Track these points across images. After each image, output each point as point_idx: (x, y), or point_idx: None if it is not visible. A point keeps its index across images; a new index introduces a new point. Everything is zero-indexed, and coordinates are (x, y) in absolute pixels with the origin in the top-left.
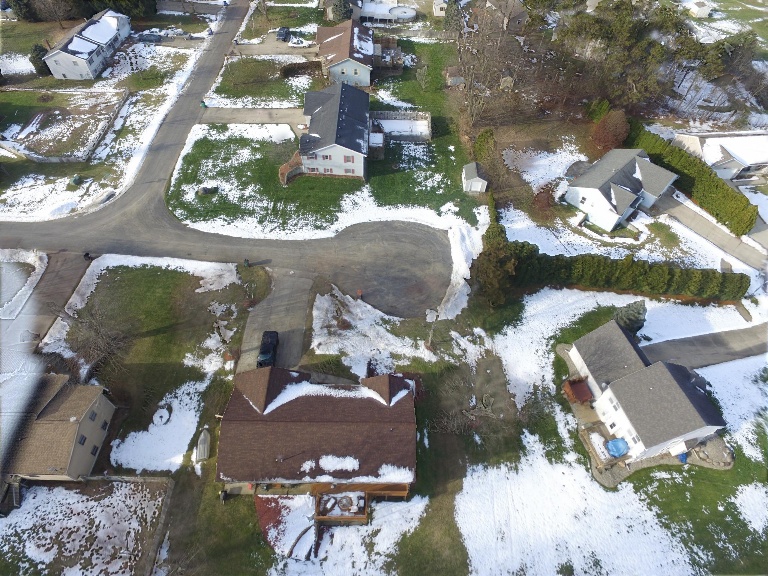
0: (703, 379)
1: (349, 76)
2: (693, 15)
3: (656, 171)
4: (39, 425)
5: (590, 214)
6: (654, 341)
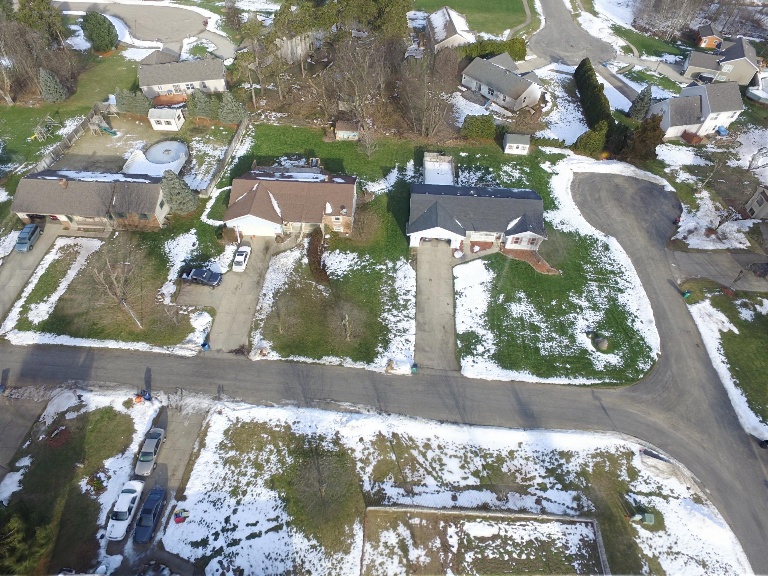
0: None
1: None
2: None
3: (502, 58)
4: None
5: (528, 104)
6: None
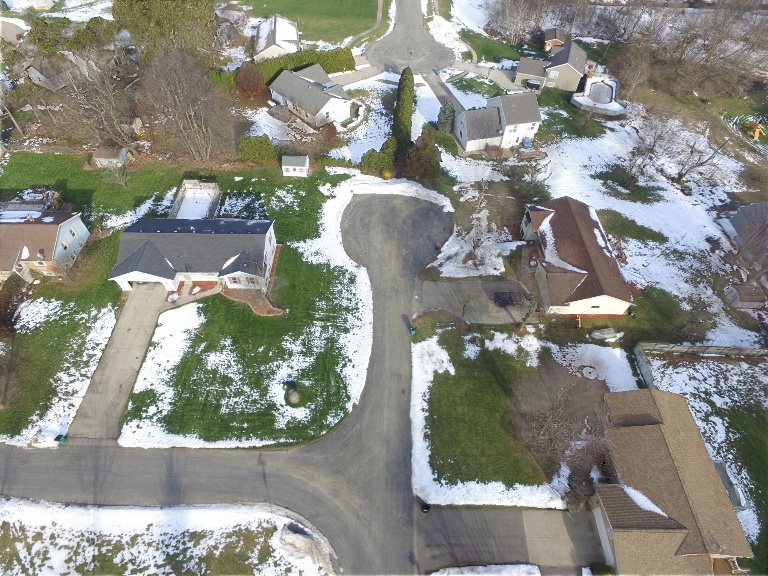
0: (498, 92)
1: (71, 245)
2: (45, 9)
3: (311, 71)
4: (666, 420)
5: (336, 119)
6: None
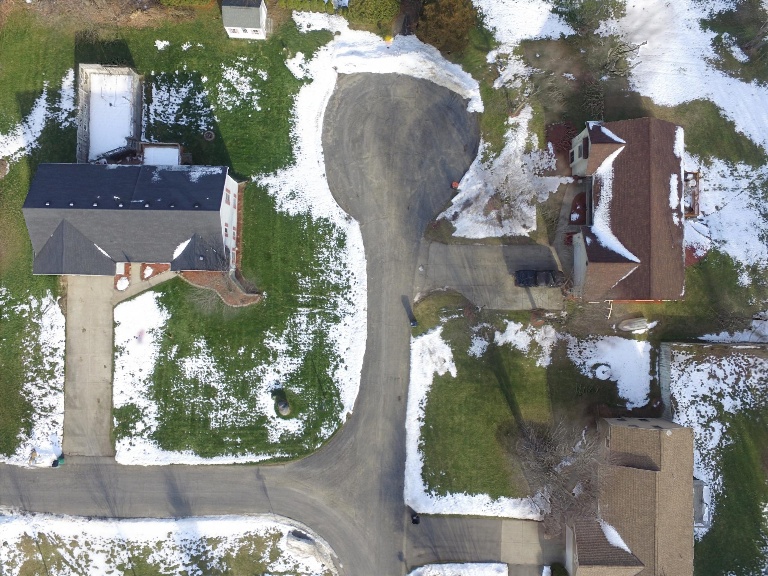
0: None
1: None
2: None
3: None
4: (664, 466)
5: None
6: None
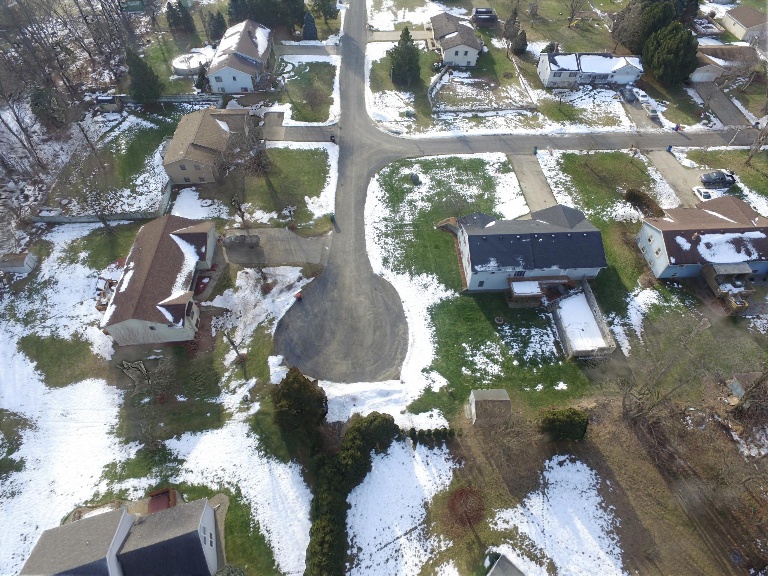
0: None
1: (651, 249)
2: None
3: None
4: None
5: None
6: None
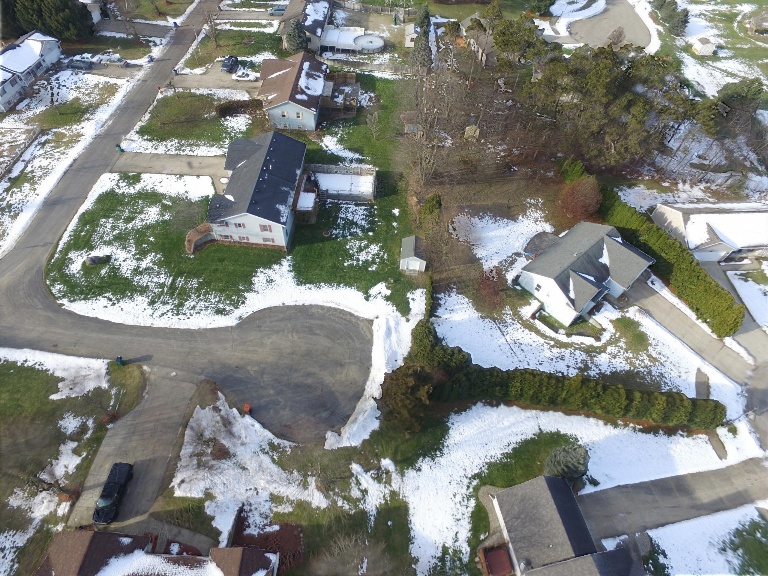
0: (646, 575)
1: (291, 119)
2: (696, 52)
3: (626, 256)
4: None
5: (546, 304)
6: (601, 486)
